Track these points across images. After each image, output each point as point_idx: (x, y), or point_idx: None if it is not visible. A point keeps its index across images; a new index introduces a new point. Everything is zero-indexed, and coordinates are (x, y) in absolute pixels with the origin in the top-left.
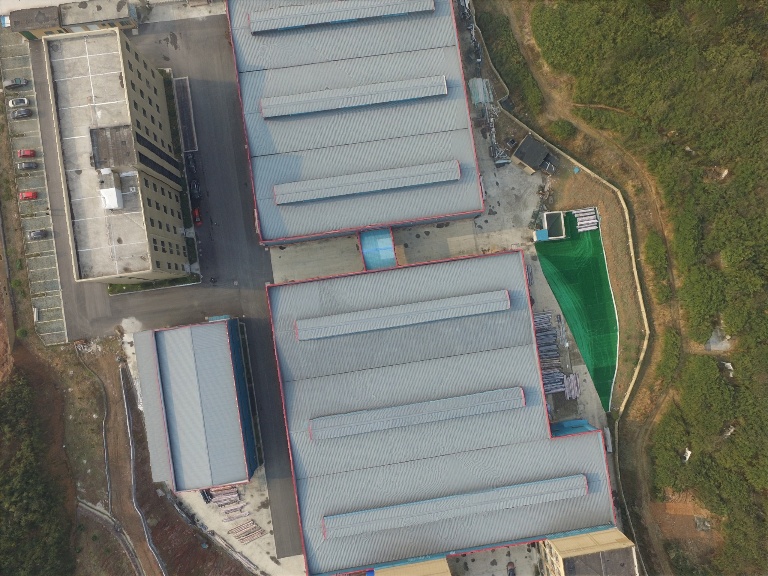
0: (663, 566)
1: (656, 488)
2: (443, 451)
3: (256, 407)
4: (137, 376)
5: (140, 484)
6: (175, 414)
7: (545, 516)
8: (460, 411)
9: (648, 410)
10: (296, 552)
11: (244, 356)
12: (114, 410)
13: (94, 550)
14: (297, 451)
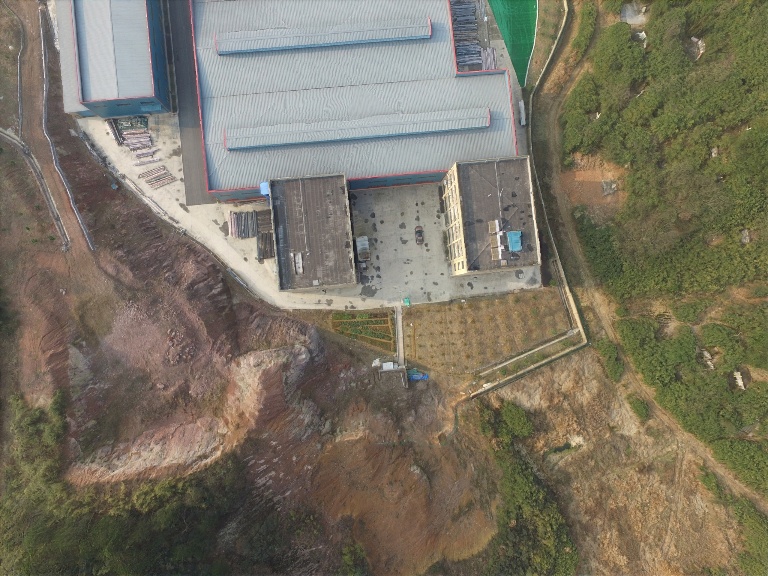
0: (570, 236)
1: (565, 152)
2: (350, 81)
3: (173, 57)
4: (56, 17)
5: (52, 117)
6: (85, 29)
7: (448, 151)
8: (366, 33)
9: (562, 80)
10: (205, 201)
11: (163, 5)
12: (31, 46)
13: None
14: (204, 68)
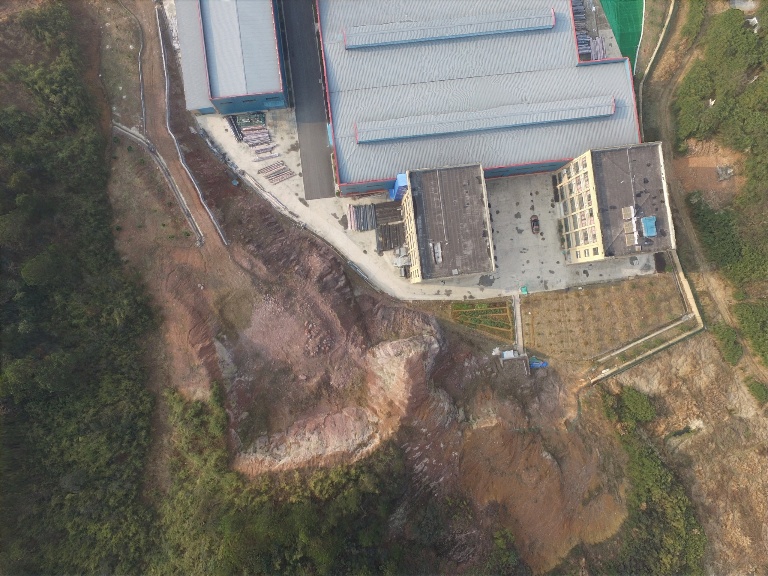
0: (685, 221)
1: (680, 138)
2: (473, 73)
3: (288, 53)
4: (173, 16)
5: (174, 114)
6: (212, 26)
7: (572, 140)
8: (491, 25)
9: (673, 68)
10: (324, 195)
11: (277, 2)
12: (150, 45)
13: (129, 160)
14: (330, 63)
